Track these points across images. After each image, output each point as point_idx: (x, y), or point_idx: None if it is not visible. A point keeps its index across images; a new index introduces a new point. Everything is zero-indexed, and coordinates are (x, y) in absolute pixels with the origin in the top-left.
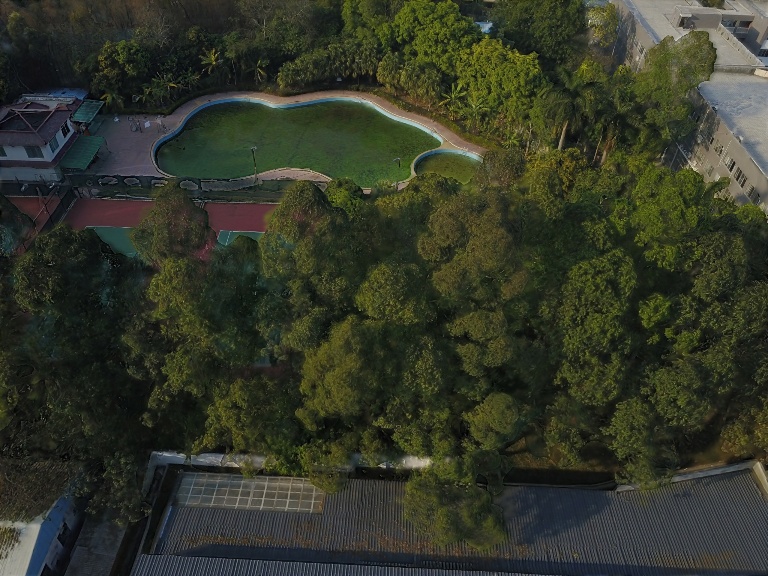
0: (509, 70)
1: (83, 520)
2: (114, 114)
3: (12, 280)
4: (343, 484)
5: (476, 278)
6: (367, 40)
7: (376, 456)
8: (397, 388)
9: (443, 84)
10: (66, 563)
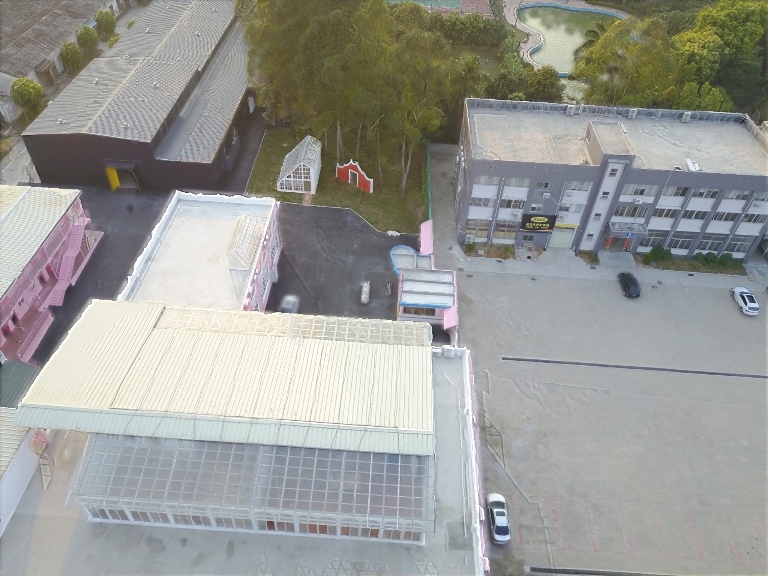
0: None
1: None
2: None
3: None
4: None
5: None
6: None
7: None
8: None
9: None
10: None
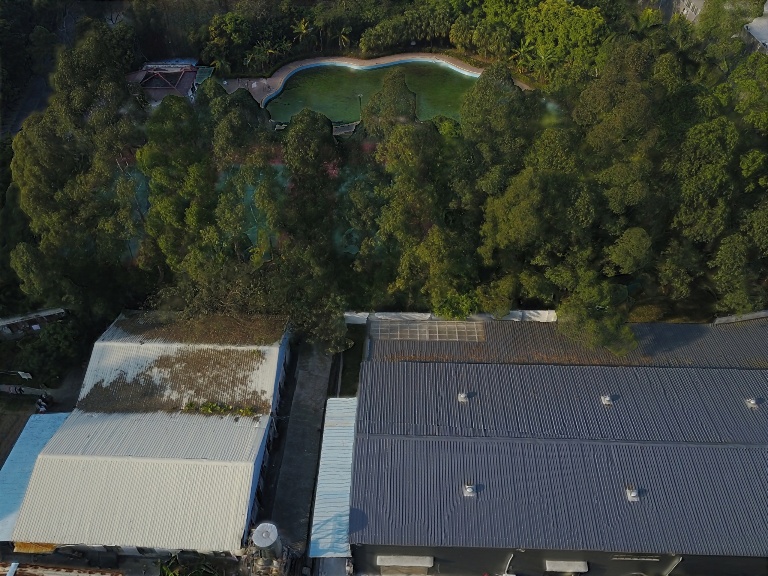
0: (576, 22)
1: (297, 356)
2: (222, 78)
3: (280, 146)
4: (509, 310)
5: (621, 134)
6: (440, 5)
7: (535, 286)
8: (559, 224)
9: (512, 40)
10: (289, 386)
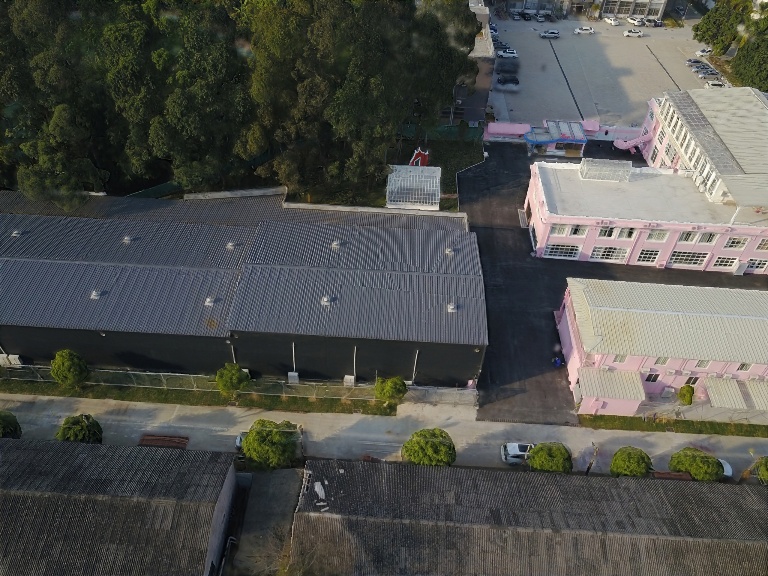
0: None
1: None
2: None
3: None
4: None
5: (32, 25)
6: None
7: (4, 153)
8: None
9: None
10: None
